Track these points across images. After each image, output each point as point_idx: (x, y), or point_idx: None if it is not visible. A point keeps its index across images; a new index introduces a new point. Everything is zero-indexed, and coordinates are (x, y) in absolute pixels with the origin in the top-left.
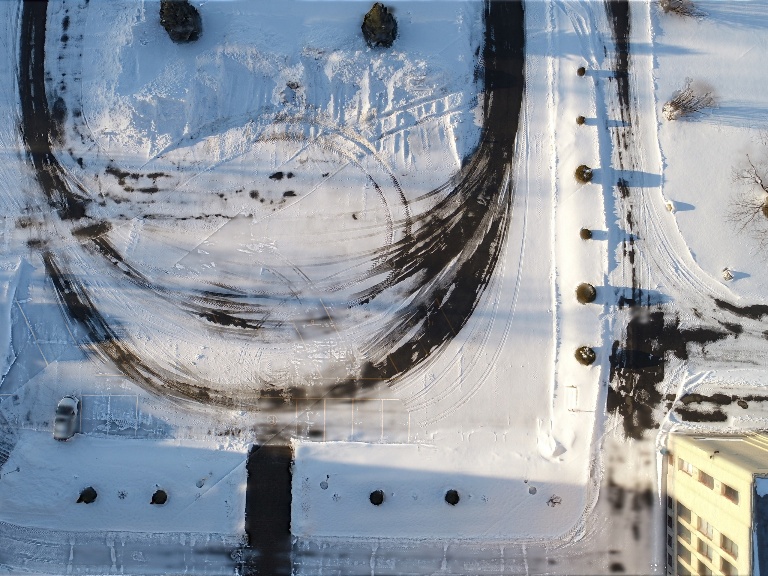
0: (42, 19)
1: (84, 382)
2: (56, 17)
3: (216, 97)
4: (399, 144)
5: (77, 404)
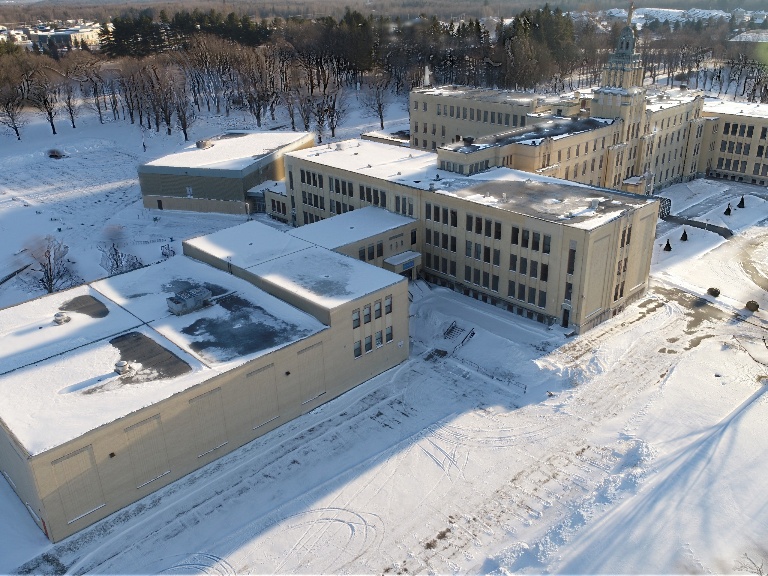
0: None
1: None
2: None
3: None
4: None
5: None
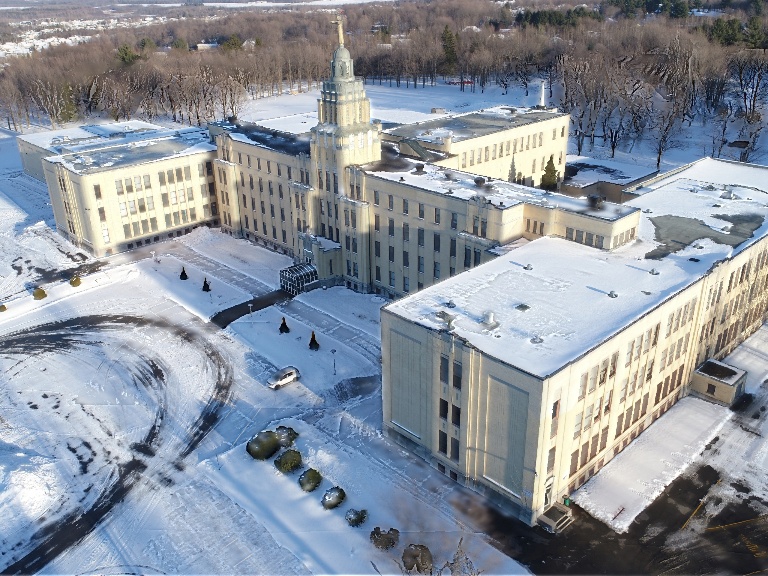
0: None
1: None
2: None
3: None
4: None
5: None
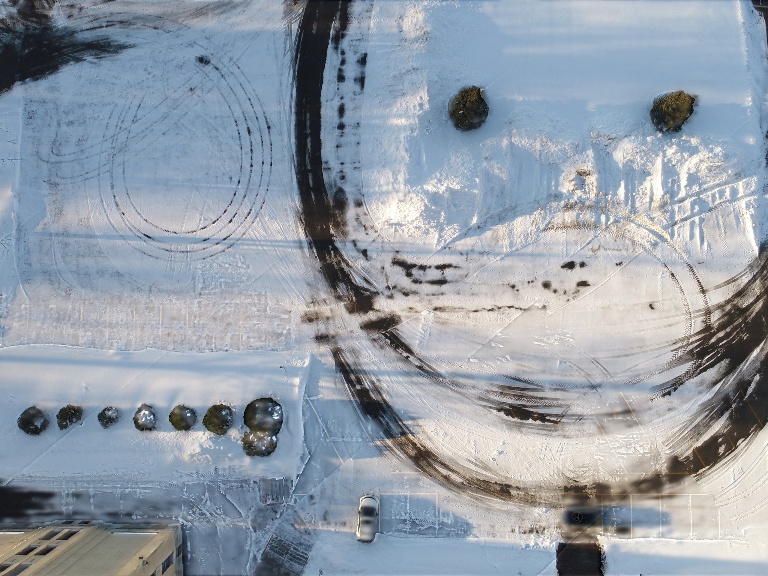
0: (317, 106)
1: (381, 480)
2: (331, 104)
3: (504, 186)
4: (694, 231)
5: (378, 504)
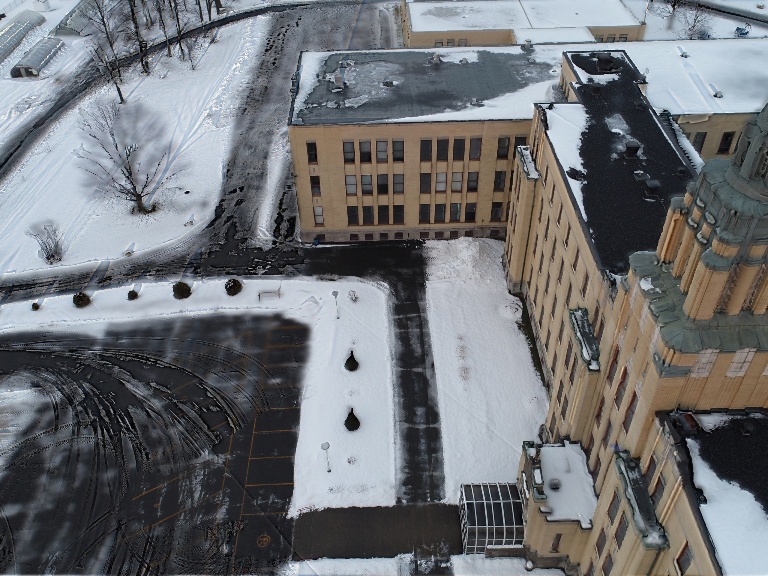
0: None
1: None
2: None
3: None
4: None
5: None
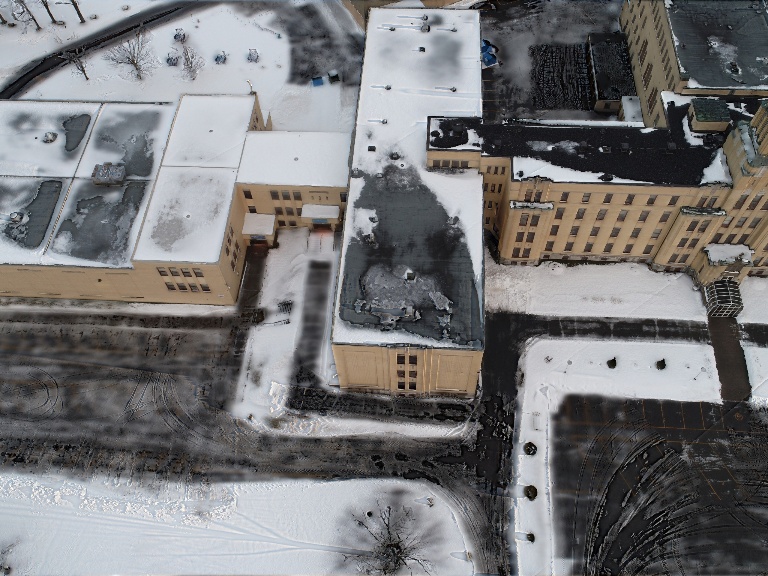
0: None
1: None
2: None
3: None
4: None
5: None
